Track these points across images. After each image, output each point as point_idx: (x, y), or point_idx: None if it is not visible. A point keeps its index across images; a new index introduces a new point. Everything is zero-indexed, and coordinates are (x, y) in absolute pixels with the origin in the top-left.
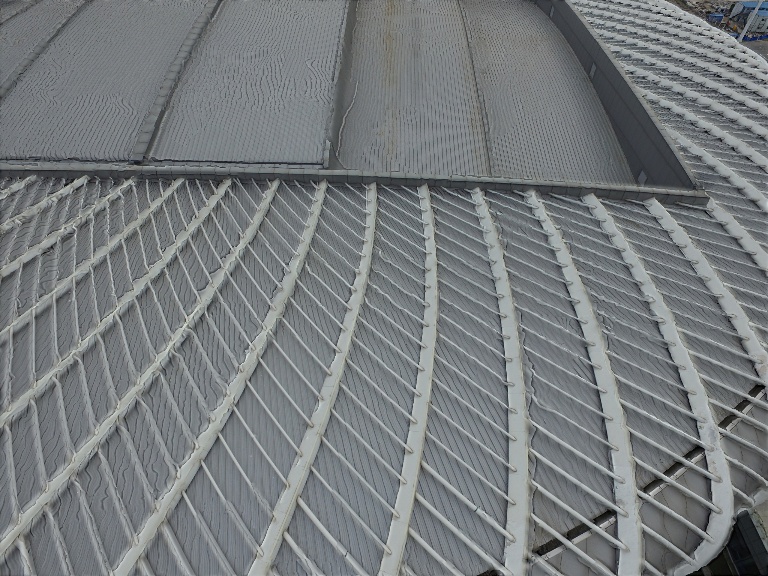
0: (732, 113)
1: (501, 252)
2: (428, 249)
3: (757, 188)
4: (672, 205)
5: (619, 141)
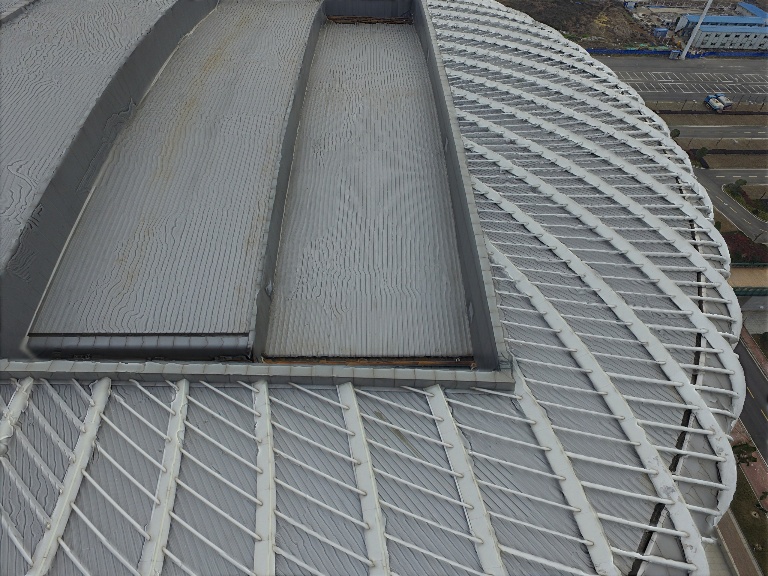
0: (591, 218)
1: (161, 520)
2: (53, 515)
3: (595, 348)
4: (467, 390)
5: (458, 248)
